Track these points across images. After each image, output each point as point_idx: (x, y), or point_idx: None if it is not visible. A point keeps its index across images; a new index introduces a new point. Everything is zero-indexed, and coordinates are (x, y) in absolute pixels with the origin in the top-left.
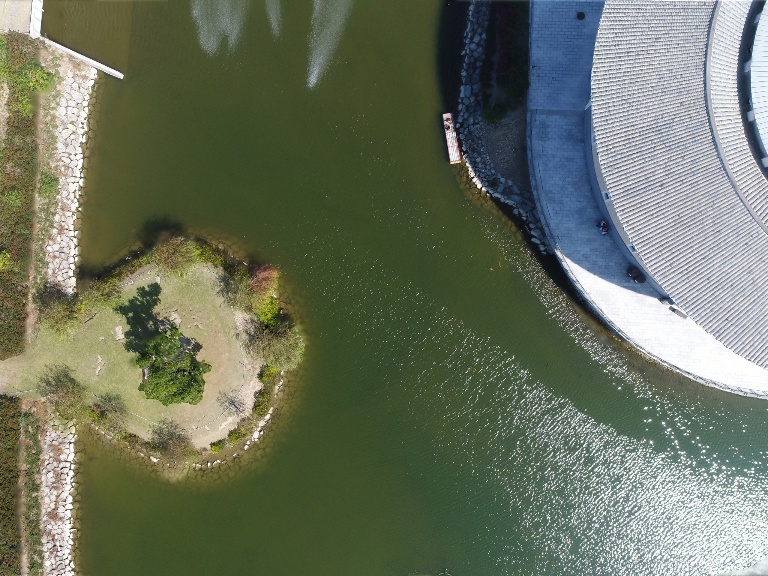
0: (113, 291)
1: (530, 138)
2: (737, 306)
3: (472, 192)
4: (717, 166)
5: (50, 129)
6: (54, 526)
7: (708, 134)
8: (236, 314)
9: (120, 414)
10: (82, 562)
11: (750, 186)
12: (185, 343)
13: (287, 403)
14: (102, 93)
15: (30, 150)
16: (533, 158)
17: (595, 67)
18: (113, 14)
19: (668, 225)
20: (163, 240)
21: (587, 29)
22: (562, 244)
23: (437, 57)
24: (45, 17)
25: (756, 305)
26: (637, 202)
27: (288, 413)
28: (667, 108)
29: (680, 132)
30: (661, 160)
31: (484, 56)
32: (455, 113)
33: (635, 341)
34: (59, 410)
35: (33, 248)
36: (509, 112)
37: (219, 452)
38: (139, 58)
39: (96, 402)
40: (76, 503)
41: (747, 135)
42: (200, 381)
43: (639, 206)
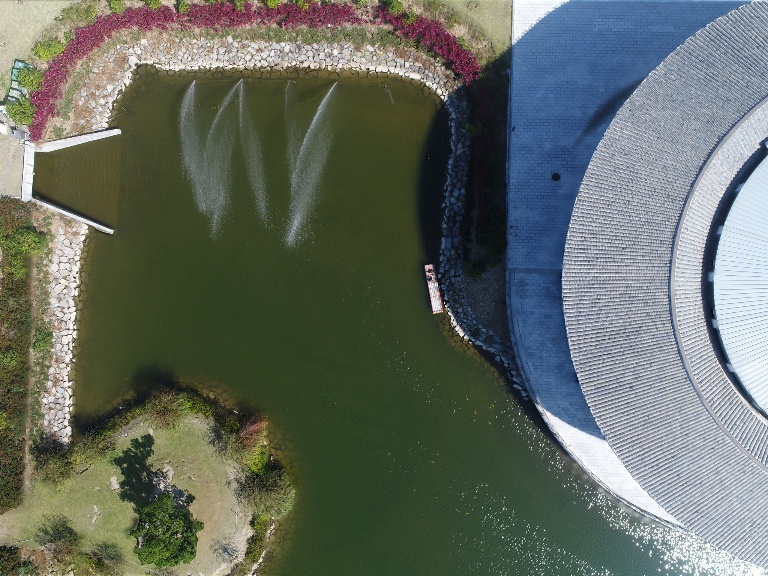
0: (107, 444)
1: (509, 296)
2: (706, 501)
3: (455, 340)
4: (683, 376)
5: (43, 285)
6: None
7: (674, 346)
8: (227, 464)
9: (117, 562)
10: None
11: (715, 393)
12: (178, 495)
13: (279, 546)
14: (93, 247)
15: (24, 310)
16: (512, 315)
17: (566, 268)
18: (102, 170)
19: (638, 424)
20: (155, 390)
21: (562, 190)
22: (542, 398)
23: (418, 209)
24: (36, 178)
25: (724, 502)
26: (608, 400)
27: (280, 555)
28: (634, 316)
29: (647, 340)
30: (630, 364)
31: (464, 210)
32: (437, 264)
33: (615, 491)
34: (57, 557)
35: (29, 402)
36: (489, 268)
37: None
38: (128, 212)
39: (93, 550)
40: None
41: (712, 340)
42: (193, 540)
43: (610, 403)
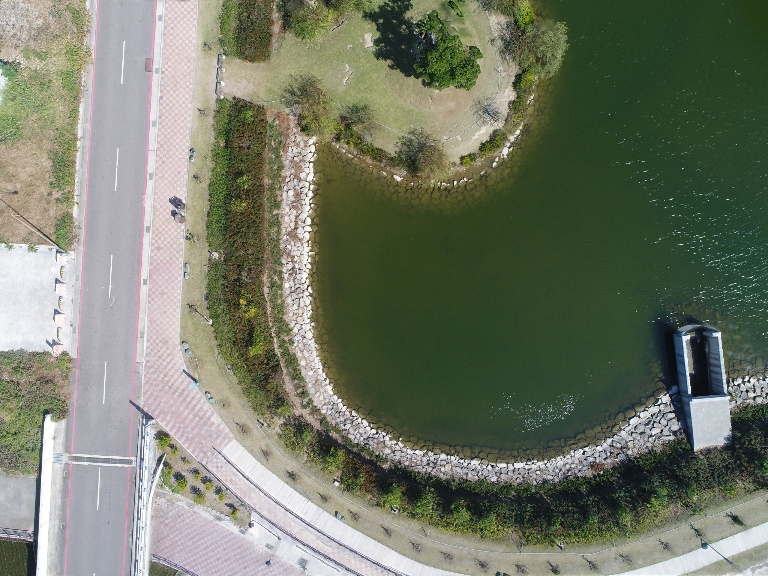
0: None
1: None
2: None
3: None
4: None
5: None
6: (293, 247)
7: None
8: (491, 20)
9: (368, 125)
10: (319, 288)
11: None
12: None
13: (536, 120)
14: None
15: None
16: None
17: None
18: None
19: None
20: None
21: None
22: None
23: None
24: None
25: None
26: None
27: (537, 131)
28: None
29: None
30: None
31: None
32: None
33: None
34: (302, 124)
35: None
36: None
37: (466, 170)
38: None
39: (342, 113)
40: (314, 226)
41: None
42: None
43: None
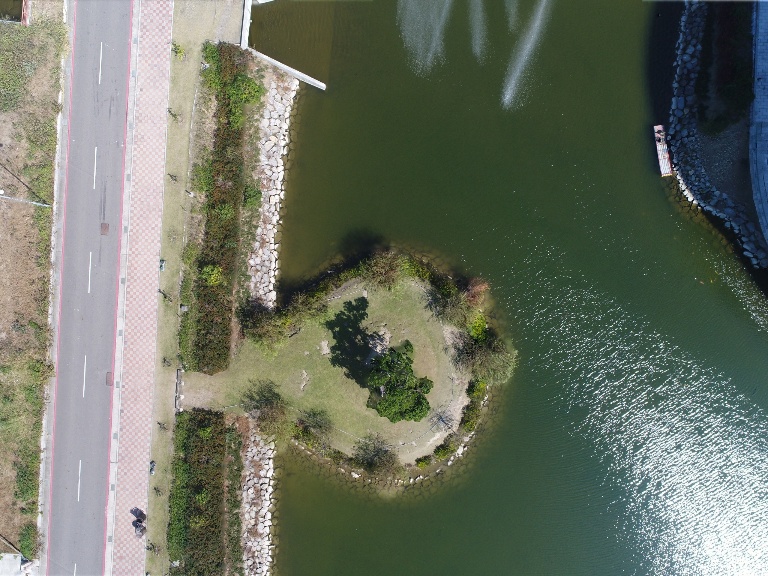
0: (320, 305)
1: (755, 151)
2: None
3: (682, 205)
4: None
5: (253, 141)
6: (254, 543)
7: None
8: (445, 328)
9: (325, 430)
10: None
11: None
12: None
13: (491, 418)
14: (303, 104)
15: (238, 163)
16: (758, 171)
17: None
18: (314, 24)
19: None
20: (366, 253)
21: None
22: None
23: (647, 68)
24: (251, 28)
25: None
26: None
27: (491, 428)
28: None
29: None
30: None
31: (699, 67)
32: (666, 125)
33: None
34: (261, 425)
35: (237, 262)
36: (729, 124)
37: (422, 468)
38: (340, 69)
39: (300, 417)
40: (274, 519)
41: None
42: None
43: None
